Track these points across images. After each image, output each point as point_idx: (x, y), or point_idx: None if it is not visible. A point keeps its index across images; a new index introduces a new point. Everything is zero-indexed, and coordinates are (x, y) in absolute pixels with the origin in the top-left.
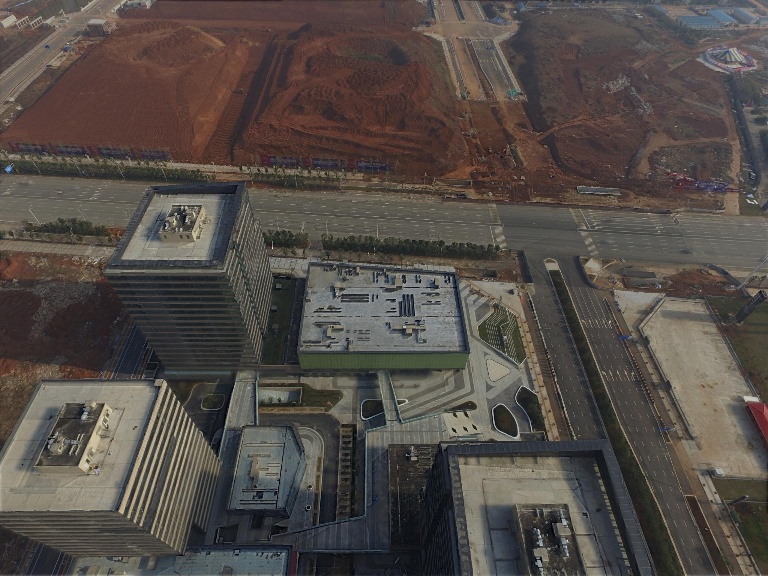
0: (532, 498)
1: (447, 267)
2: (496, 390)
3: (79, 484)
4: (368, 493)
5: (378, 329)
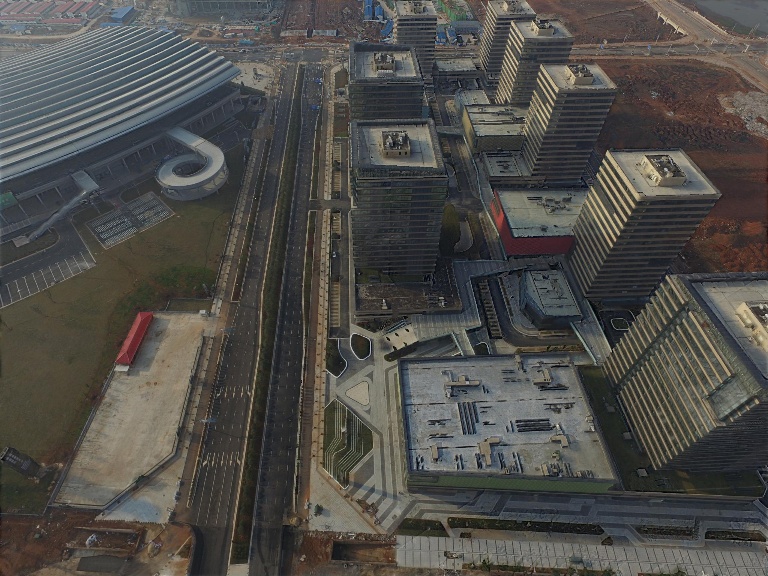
0: (398, 161)
1: (409, 565)
2: (364, 373)
3: (639, 160)
4: (470, 288)
5: (496, 384)
